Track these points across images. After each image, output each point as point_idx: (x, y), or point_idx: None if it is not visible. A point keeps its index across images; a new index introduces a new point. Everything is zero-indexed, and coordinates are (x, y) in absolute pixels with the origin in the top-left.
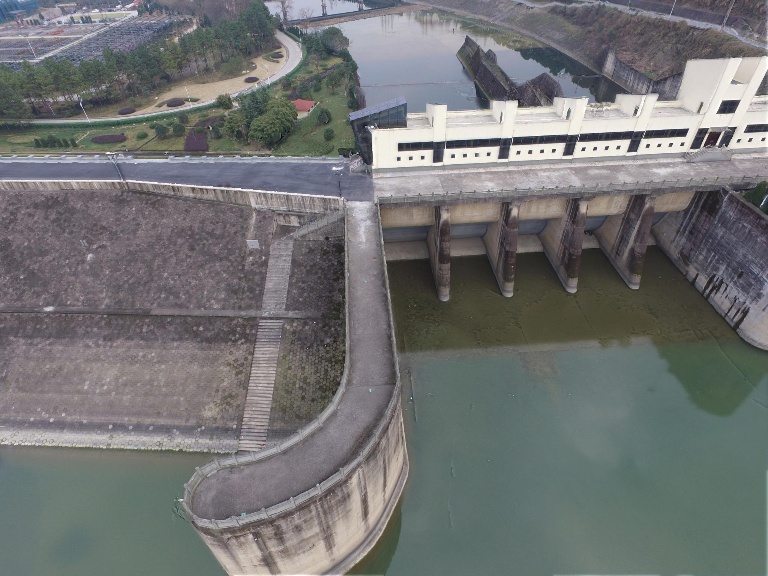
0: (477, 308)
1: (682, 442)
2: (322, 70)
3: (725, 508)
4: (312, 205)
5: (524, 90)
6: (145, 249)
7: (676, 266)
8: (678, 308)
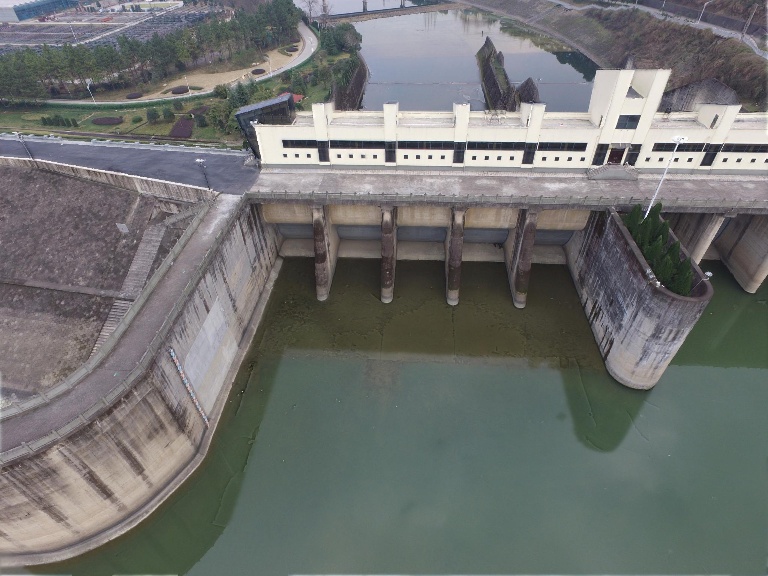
0: (349, 311)
1: (490, 470)
2: (328, 65)
3: (500, 544)
4: (187, 195)
5: (509, 95)
6: (37, 224)
7: (576, 288)
8: (556, 332)
